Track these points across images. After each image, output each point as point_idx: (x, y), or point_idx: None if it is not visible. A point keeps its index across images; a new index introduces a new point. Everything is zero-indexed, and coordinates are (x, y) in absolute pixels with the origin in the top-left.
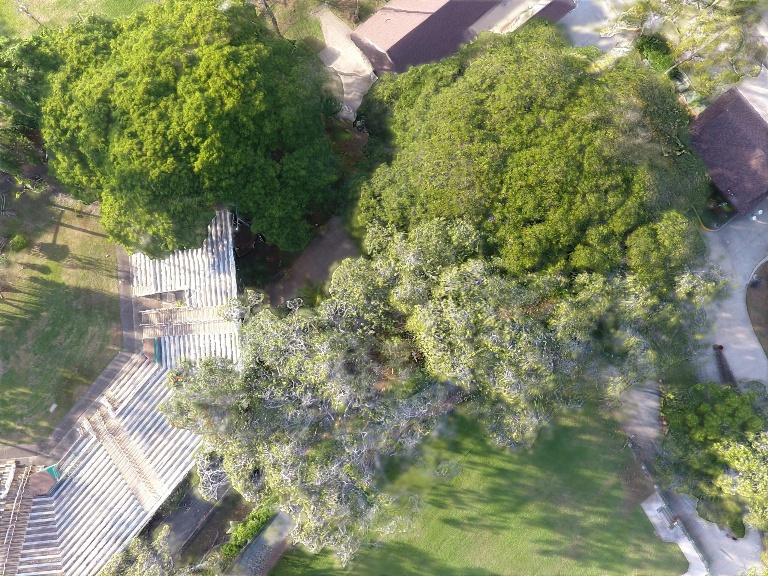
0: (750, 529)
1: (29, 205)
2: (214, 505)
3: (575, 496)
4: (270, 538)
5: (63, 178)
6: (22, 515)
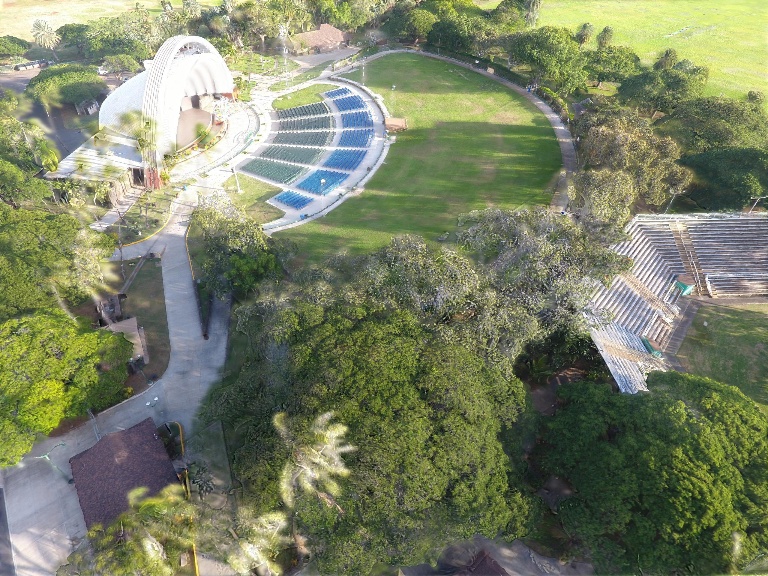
0: None
1: None
2: None
3: None
4: None
5: None
6: (688, 267)
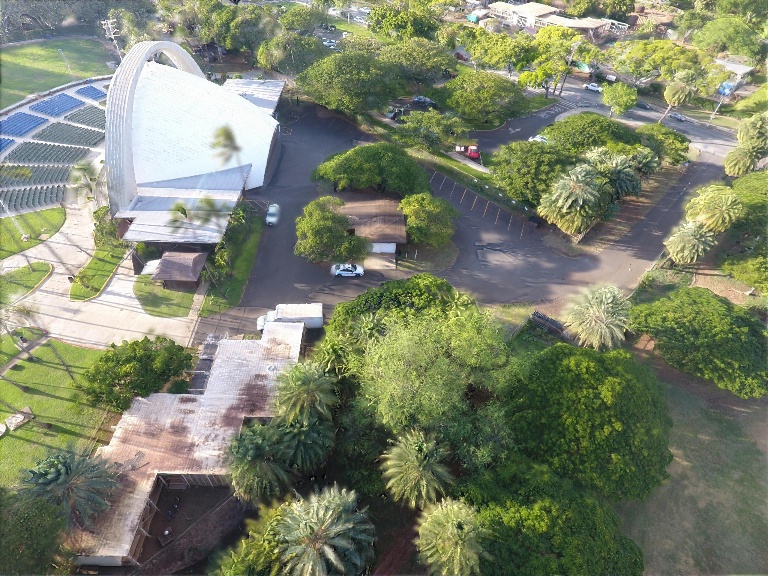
0: None
1: None
2: None
3: (80, 58)
4: None
5: None
6: None
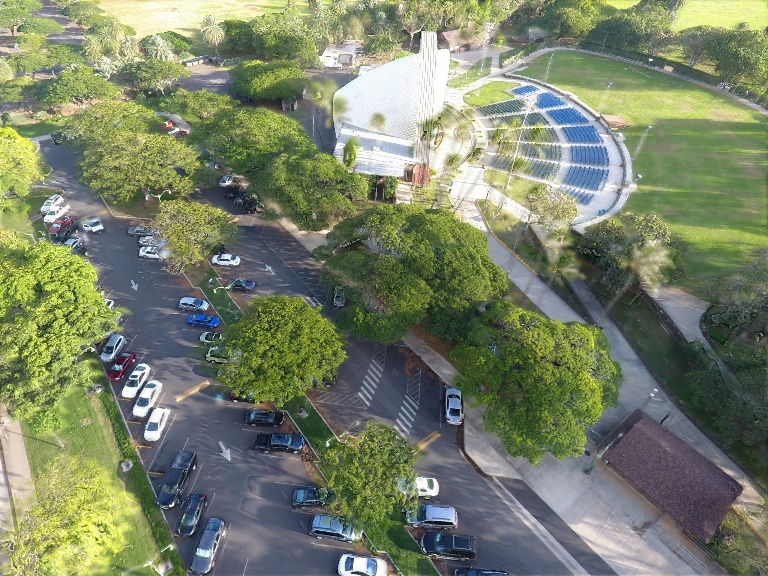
0: None
1: None
2: None
3: None
4: None
5: None
6: None
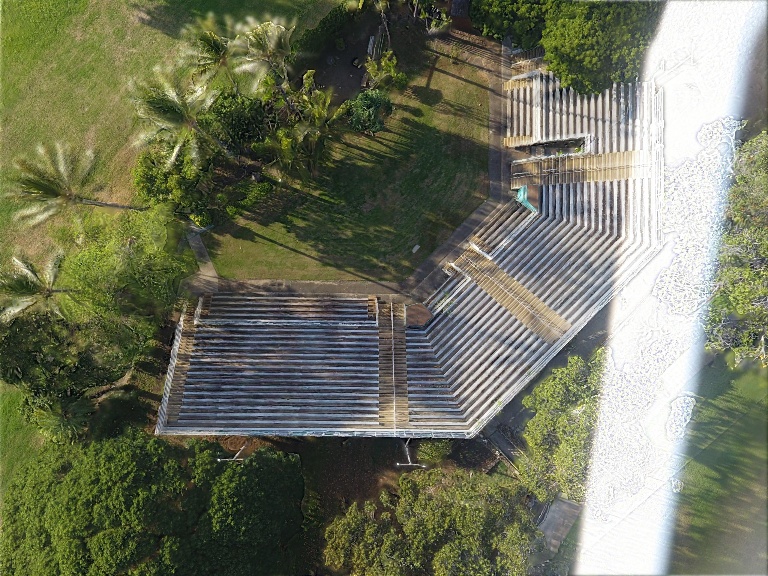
0: None
1: (405, 47)
2: None
3: None
4: None
5: (491, 7)
6: (398, 344)
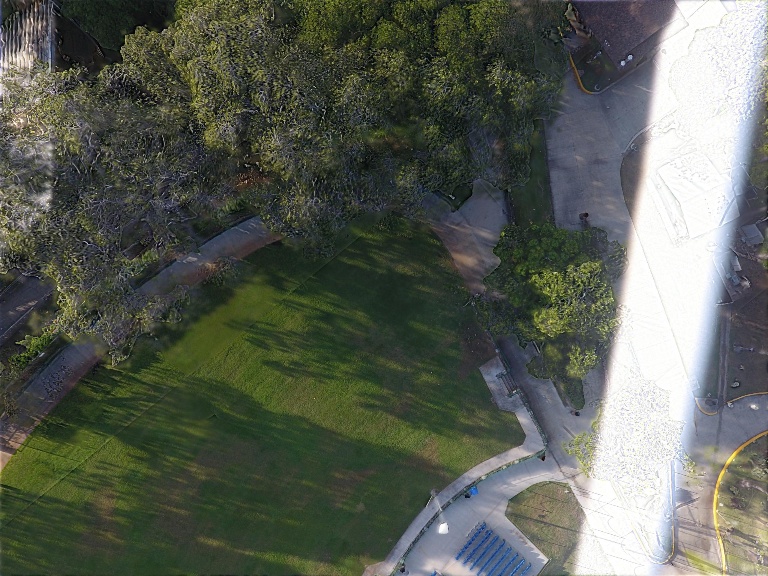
0: (597, 408)
1: None
2: (16, 321)
3: (408, 351)
4: (70, 359)
5: None
6: None
